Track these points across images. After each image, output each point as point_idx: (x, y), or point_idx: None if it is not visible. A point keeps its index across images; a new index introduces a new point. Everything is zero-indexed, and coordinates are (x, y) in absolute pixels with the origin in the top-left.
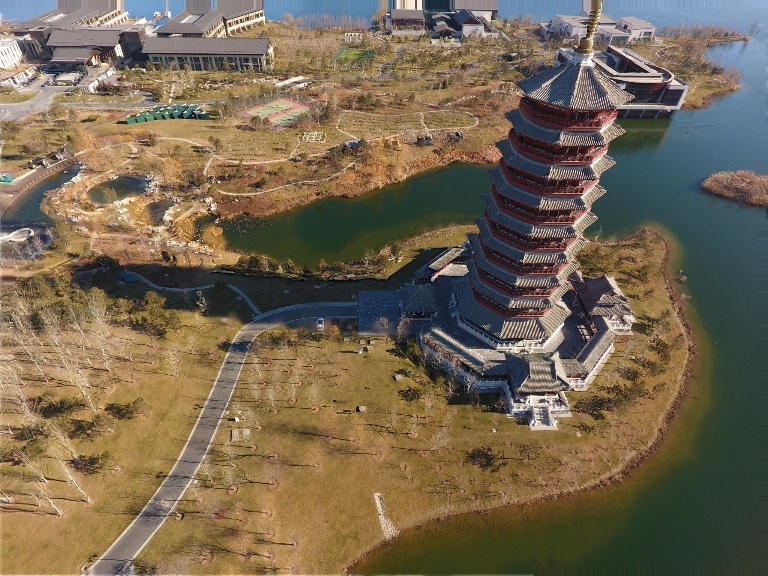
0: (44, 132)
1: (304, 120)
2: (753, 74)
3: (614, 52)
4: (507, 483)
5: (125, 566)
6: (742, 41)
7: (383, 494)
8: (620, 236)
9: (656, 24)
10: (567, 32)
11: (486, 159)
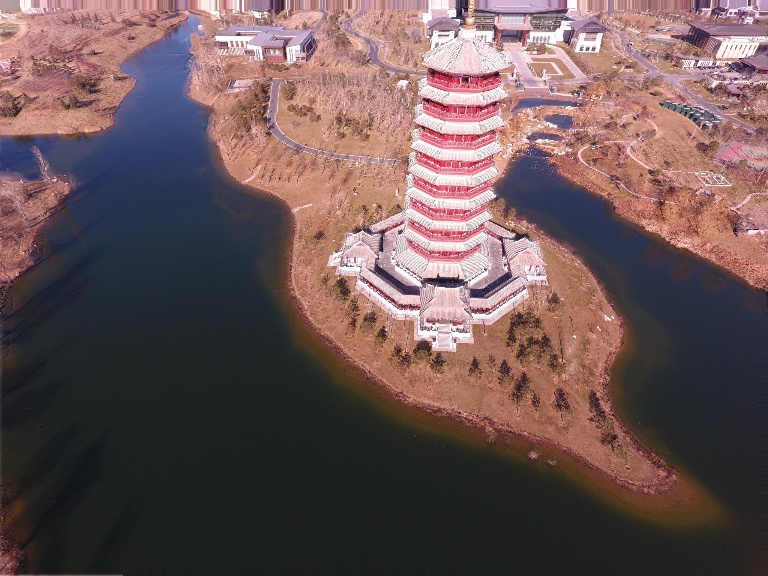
0: (624, 87)
1: (741, 167)
2: None
3: None
4: (303, 245)
5: (301, 150)
6: None
7: (311, 206)
8: (637, 430)
9: None
10: None
11: None
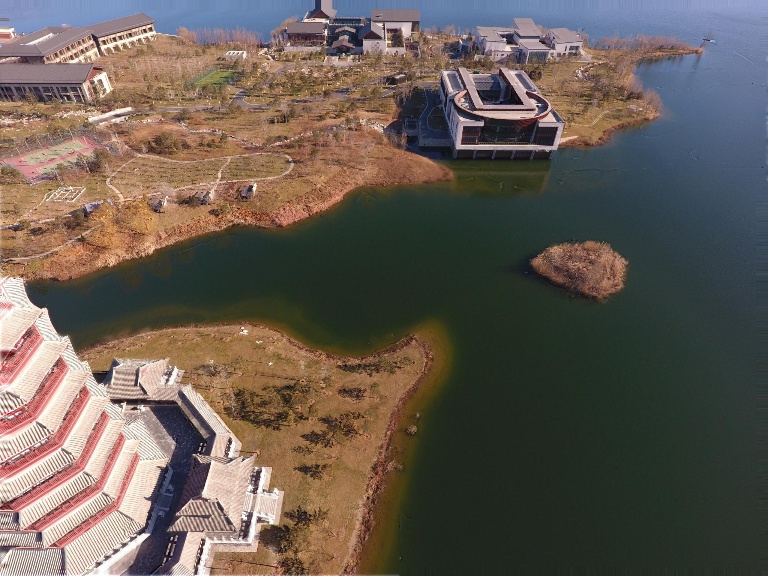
0: None
1: (65, 171)
2: (683, 98)
3: (503, 75)
4: None
5: None
6: (694, 54)
7: None
8: (374, 347)
9: (593, 35)
10: (482, 47)
11: (274, 222)
